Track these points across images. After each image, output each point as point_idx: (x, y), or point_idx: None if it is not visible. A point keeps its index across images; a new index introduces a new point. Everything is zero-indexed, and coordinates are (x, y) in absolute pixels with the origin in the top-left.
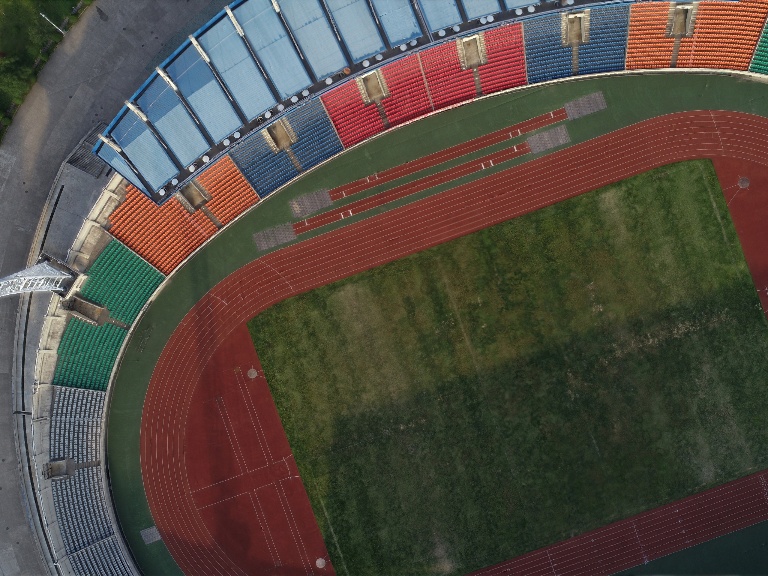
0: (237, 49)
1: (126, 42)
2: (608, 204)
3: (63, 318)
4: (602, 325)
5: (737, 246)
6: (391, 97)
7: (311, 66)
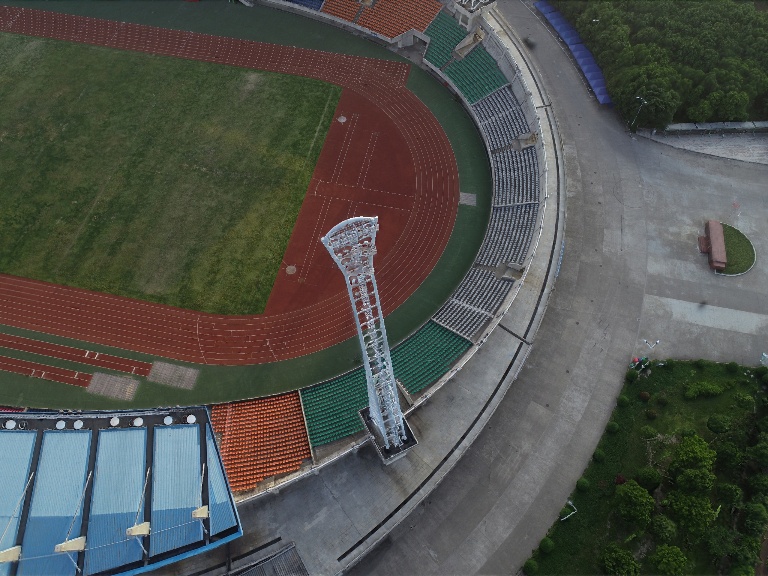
0: None
1: None
2: None
3: None
4: None
5: None
6: None
7: None
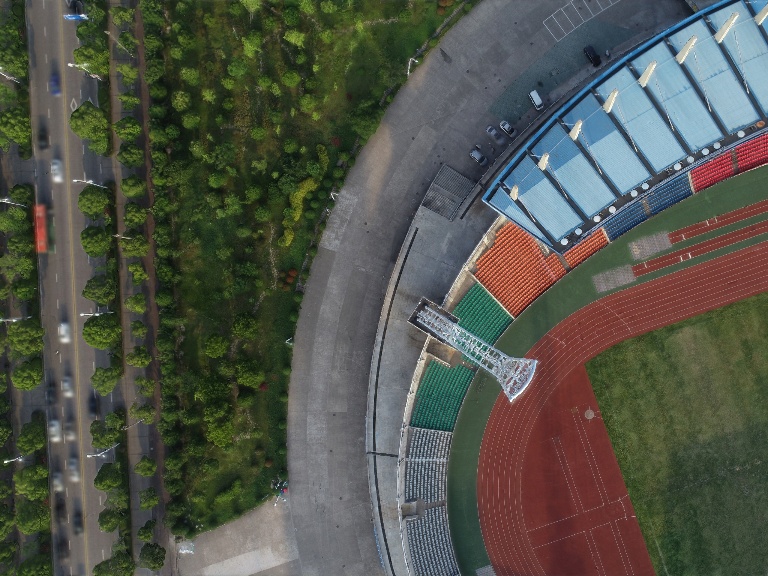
0: (639, 100)
1: (469, 84)
2: None
3: (424, 361)
4: None
5: None
6: (746, 143)
7: (721, 119)
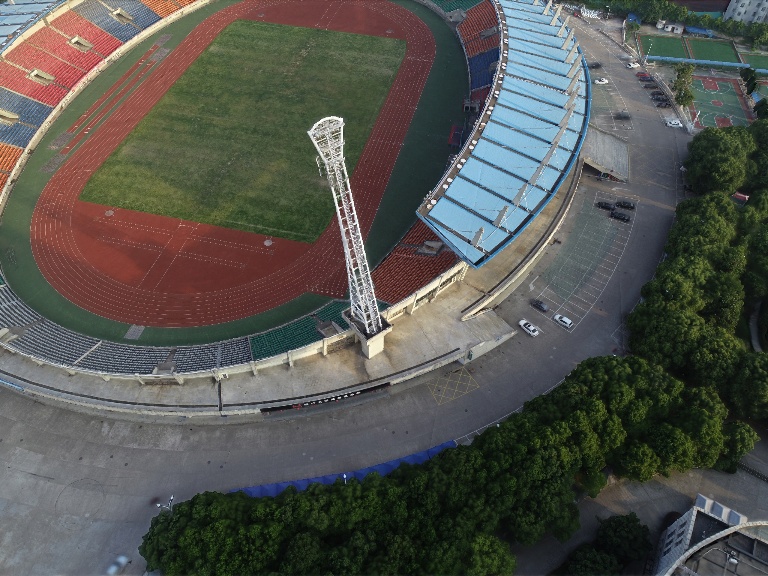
0: None
1: None
2: (215, 50)
3: None
4: (270, 73)
5: (286, 26)
6: (58, 78)
7: None
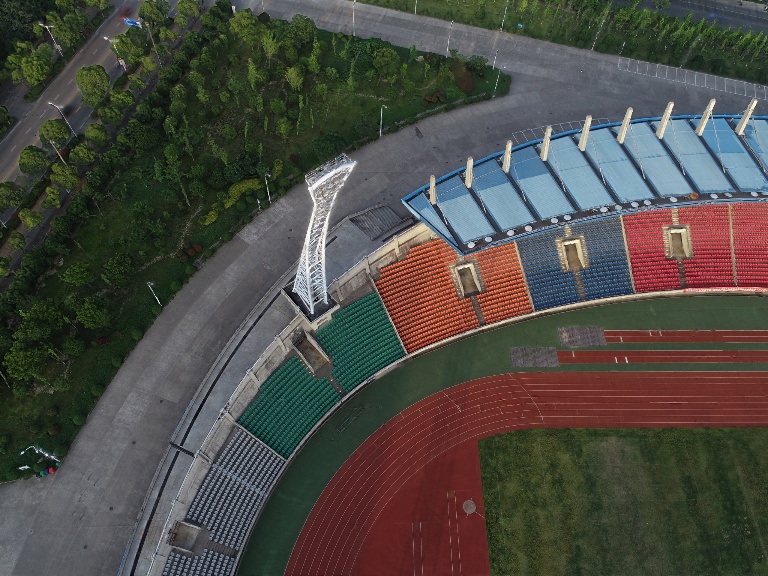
0: (576, 158)
1: (433, 156)
2: None
3: (286, 352)
4: None
5: None
6: (694, 260)
7: (654, 185)
